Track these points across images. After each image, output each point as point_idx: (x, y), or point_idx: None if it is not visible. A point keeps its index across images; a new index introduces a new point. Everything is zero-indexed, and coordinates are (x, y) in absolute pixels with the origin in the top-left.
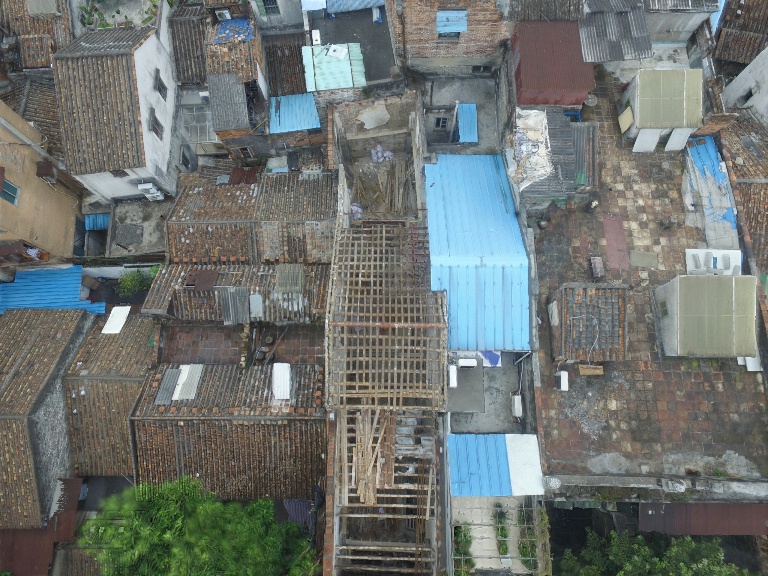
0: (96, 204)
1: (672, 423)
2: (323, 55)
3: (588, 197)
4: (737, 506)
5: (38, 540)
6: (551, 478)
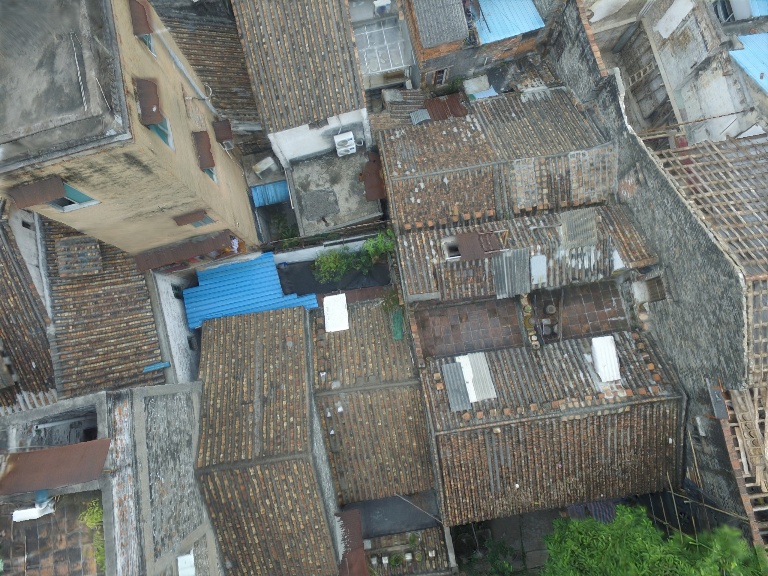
0: (266, 171)
1: None
2: None
3: None
4: None
5: None
6: None
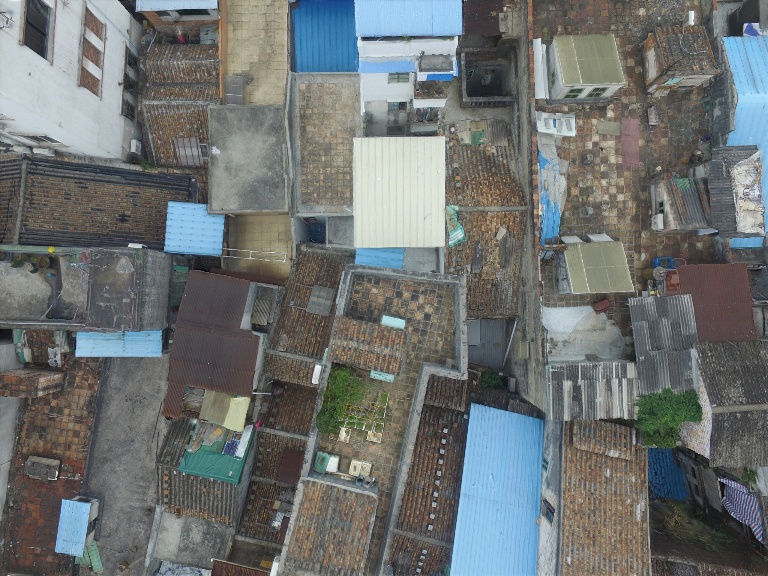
0: None
1: (598, 1)
2: None
3: (650, 185)
4: None
5: None
6: None
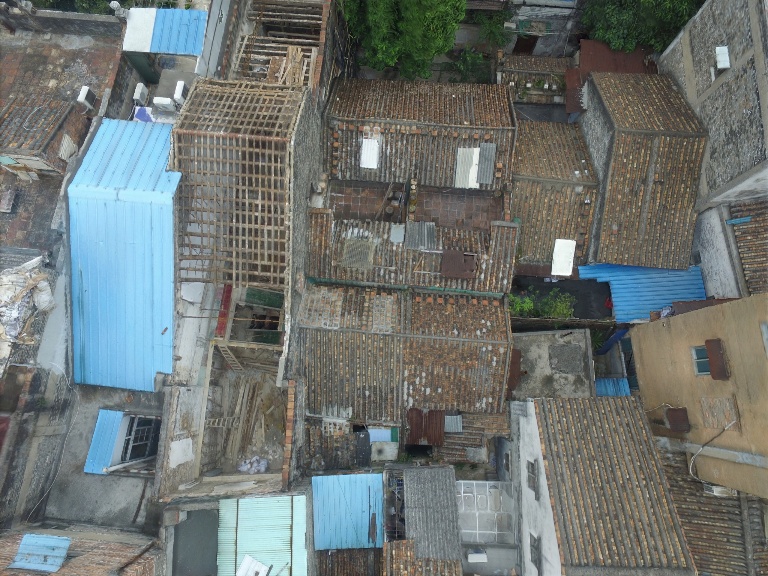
0: None
1: (8, 67)
2: (276, 568)
3: None
4: None
5: (594, 69)
6: (116, 8)
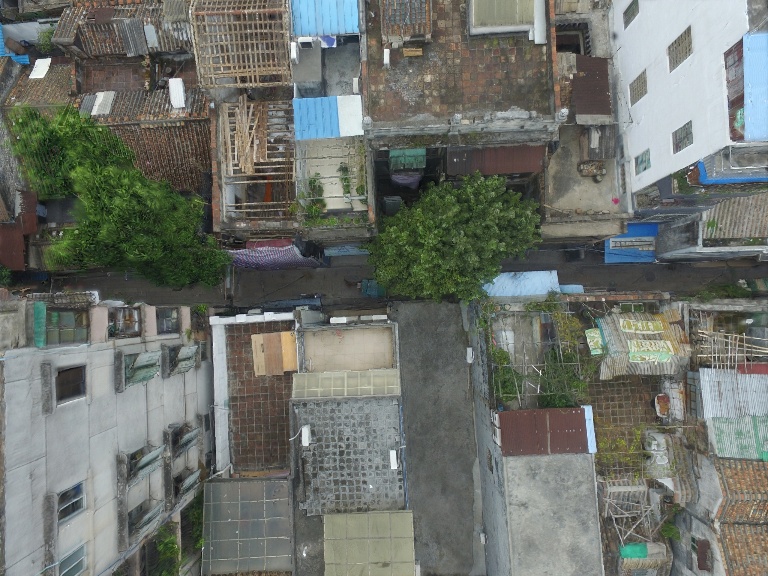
0: None
1: (472, 89)
2: None
3: None
4: (519, 151)
5: (11, 234)
6: (364, 117)
